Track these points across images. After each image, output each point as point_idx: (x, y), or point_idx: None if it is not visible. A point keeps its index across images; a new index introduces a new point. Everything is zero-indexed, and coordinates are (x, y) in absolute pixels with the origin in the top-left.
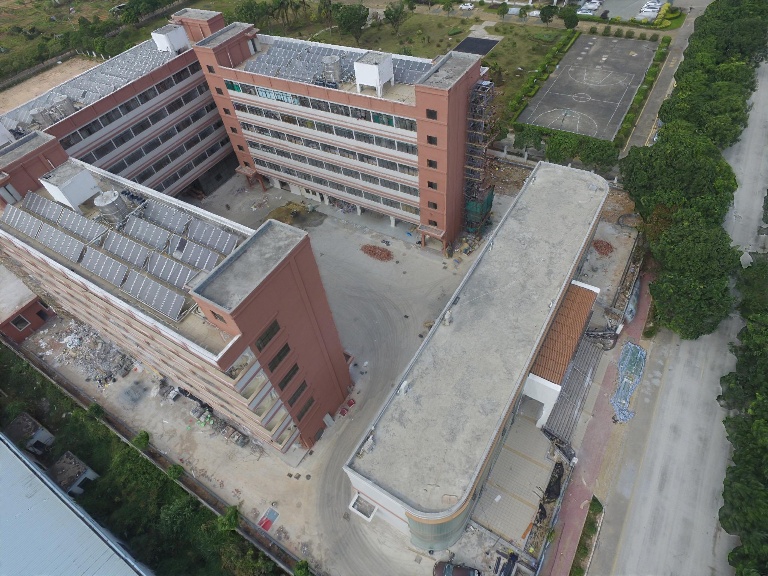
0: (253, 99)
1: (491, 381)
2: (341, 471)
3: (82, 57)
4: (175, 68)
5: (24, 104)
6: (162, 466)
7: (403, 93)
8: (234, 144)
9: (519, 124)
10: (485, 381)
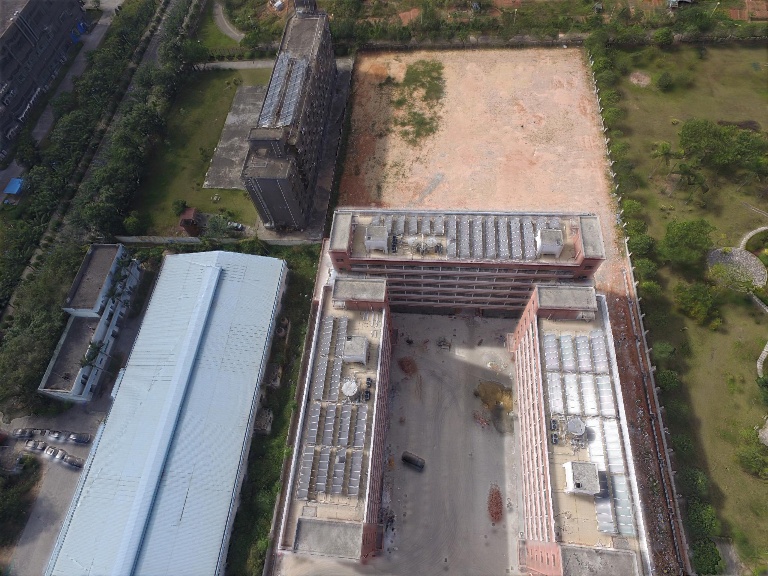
0: None
1: None
2: (323, 573)
3: (585, 54)
4: (525, 268)
5: (423, 212)
6: (286, 462)
7: (581, 511)
8: (518, 327)
9: (752, 575)
10: None
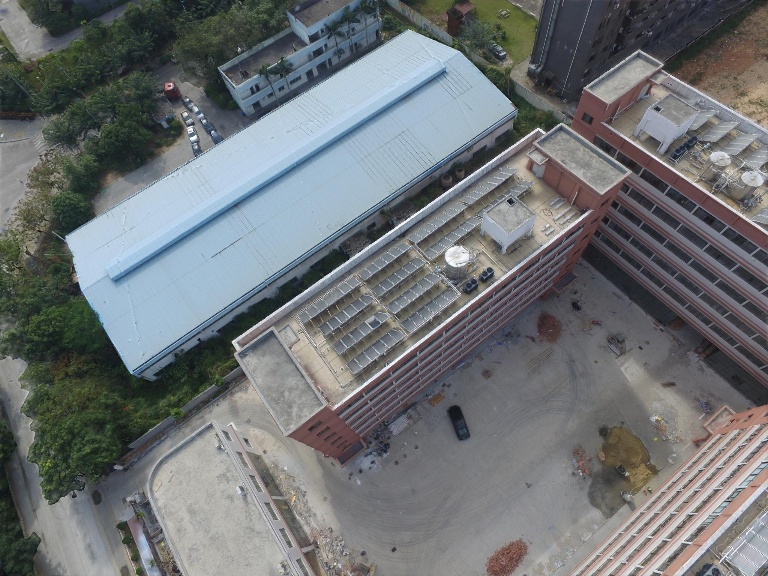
0: (767, 452)
1: (211, 572)
2: None
3: None
4: None
5: None
6: None
7: None
8: (759, 409)
9: None
10: (214, 567)
